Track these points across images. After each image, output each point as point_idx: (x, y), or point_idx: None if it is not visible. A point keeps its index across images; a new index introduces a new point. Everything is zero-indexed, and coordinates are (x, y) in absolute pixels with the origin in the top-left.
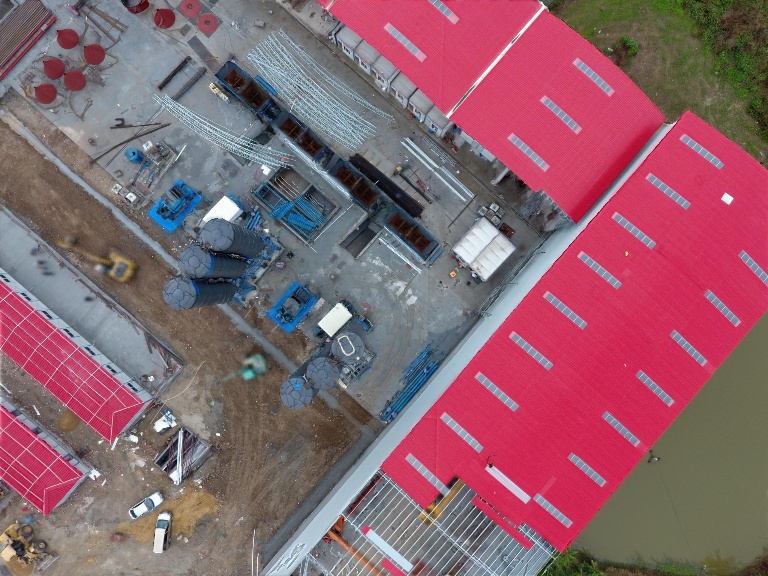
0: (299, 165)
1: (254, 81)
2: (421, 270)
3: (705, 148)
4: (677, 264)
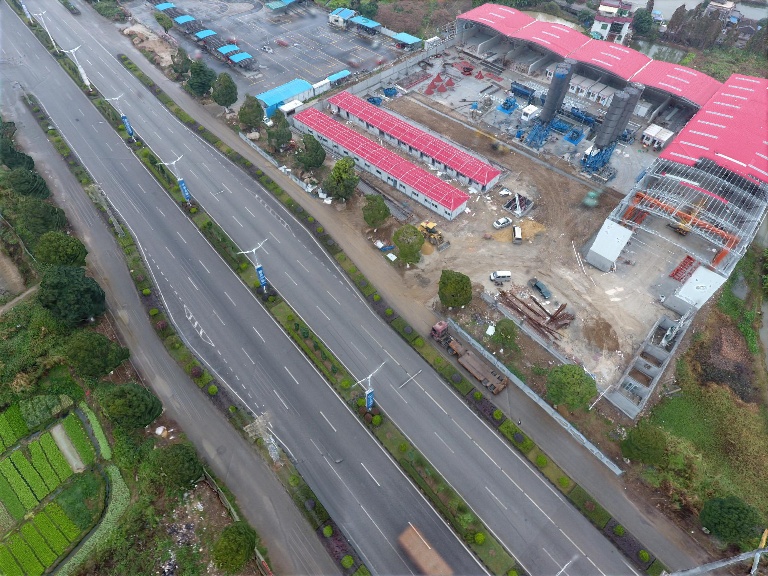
0: None
1: (527, 87)
2: (627, 146)
3: (748, 79)
4: (762, 103)
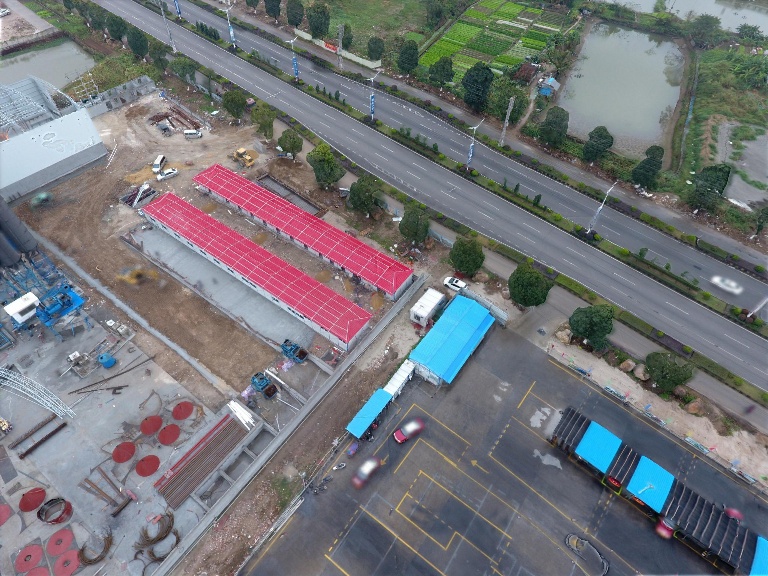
0: None
1: None
2: None
3: None
4: None
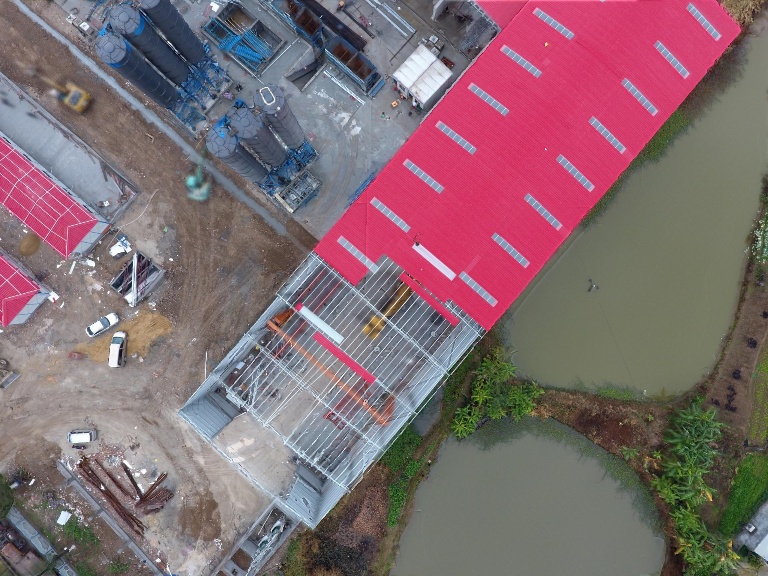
0: (246, 2)
1: None
2: (364, 102)
3: None
4: (594, 53)
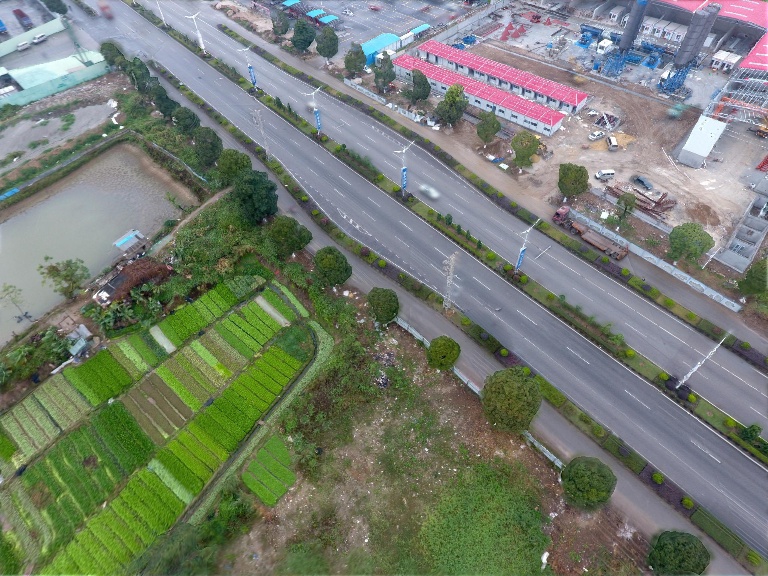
0: None
1: (596, 28)
2: (697, 71)
3: None
4: None
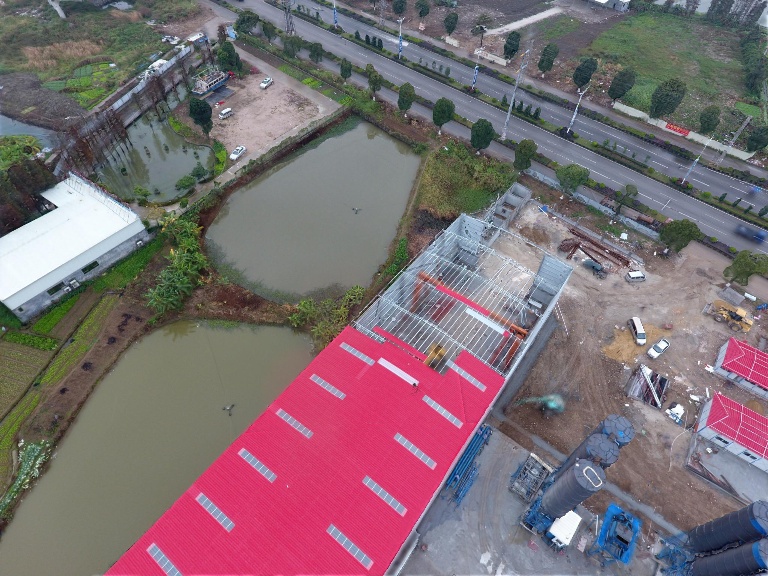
0: None
1: None
2: None
3: None
4: None
